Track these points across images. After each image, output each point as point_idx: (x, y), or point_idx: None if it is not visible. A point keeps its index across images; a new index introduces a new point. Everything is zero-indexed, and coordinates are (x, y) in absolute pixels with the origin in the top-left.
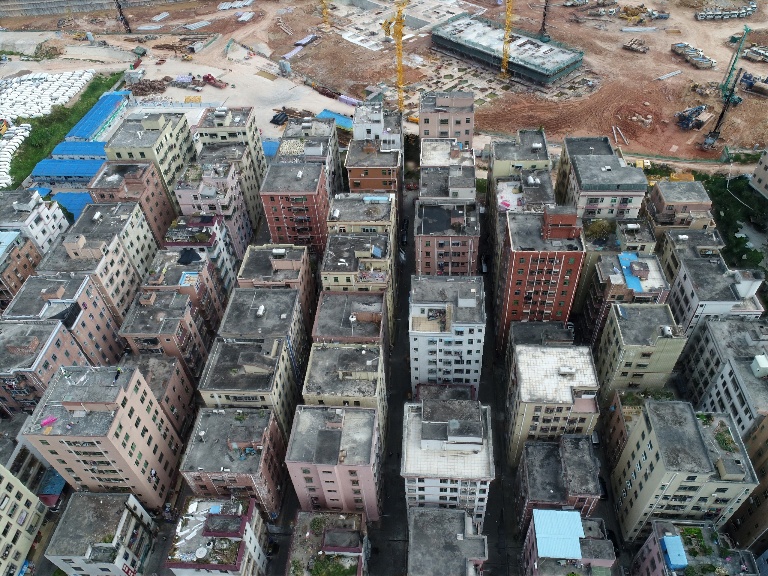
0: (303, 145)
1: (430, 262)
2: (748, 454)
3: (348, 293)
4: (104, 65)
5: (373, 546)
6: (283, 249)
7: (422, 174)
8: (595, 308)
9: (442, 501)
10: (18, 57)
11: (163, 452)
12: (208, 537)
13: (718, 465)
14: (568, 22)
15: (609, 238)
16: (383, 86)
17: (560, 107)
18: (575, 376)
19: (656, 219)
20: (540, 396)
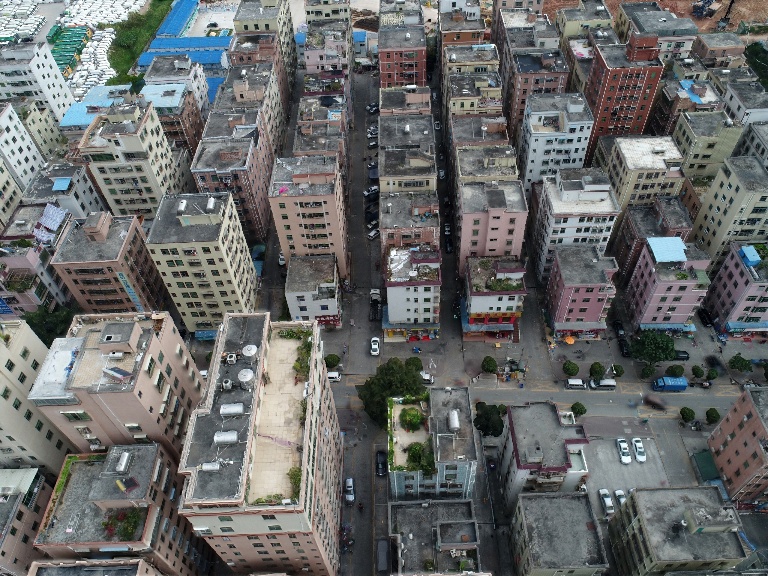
0: (399, 18)
1: (525, 99)
2: None
3: (472, 116)
4: None
5: None
6: (415, 85)
7: None
8: (662, 126)
9: (575, 244)
10: None
11: None
12: (413, 266)
13: None
14: None
15: (668, 74)
16: None
17: None
18: (665, 153)
19: None
20: (642, 166)
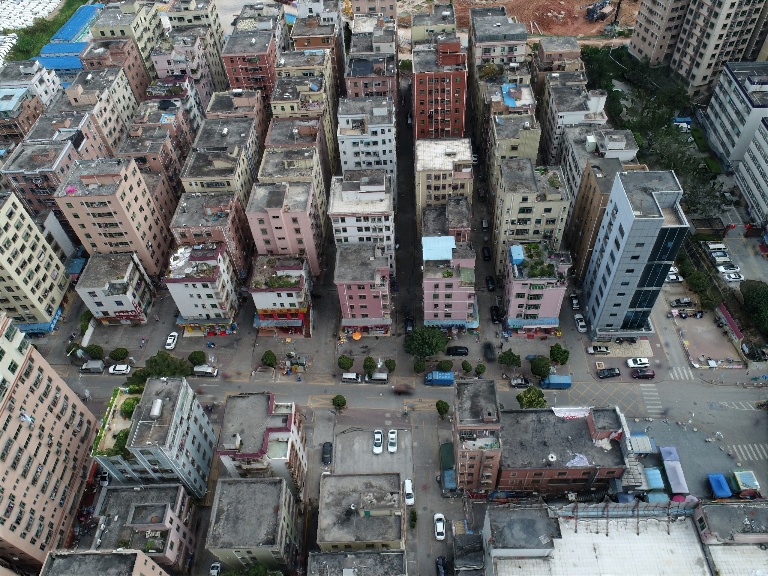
0: (256, 23)
1: None
2: (579, 203)
3: (293, 119)
4: None
5: (317, 294)
6: (241, 89)
7: (353, 39)
8: (485, 128)
9: (361, 242)
10: None
11: (156, 234)
12: (193, 264)
13: (545, 193)
14: None
15: (498, 78)
16: None
17: None
18: (457, 155)
19: (540, 68)
20: (430, 168)
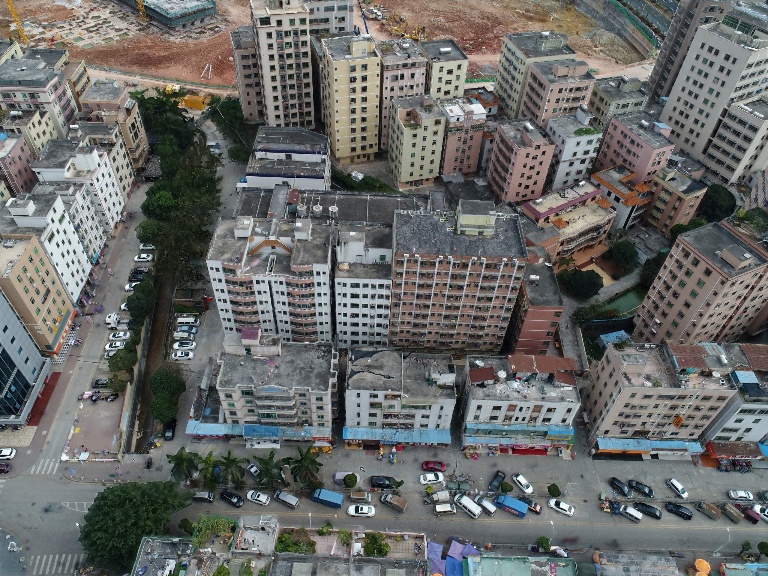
0: None
1: None
2: None
3: None
4: None
5: None
6: None
7: None
8: None
9: None
10: None
11: None
12: None
13: None
14: None
15: None
16: (26, 22)
17: (176, 47)
18: None
19: None
20: None
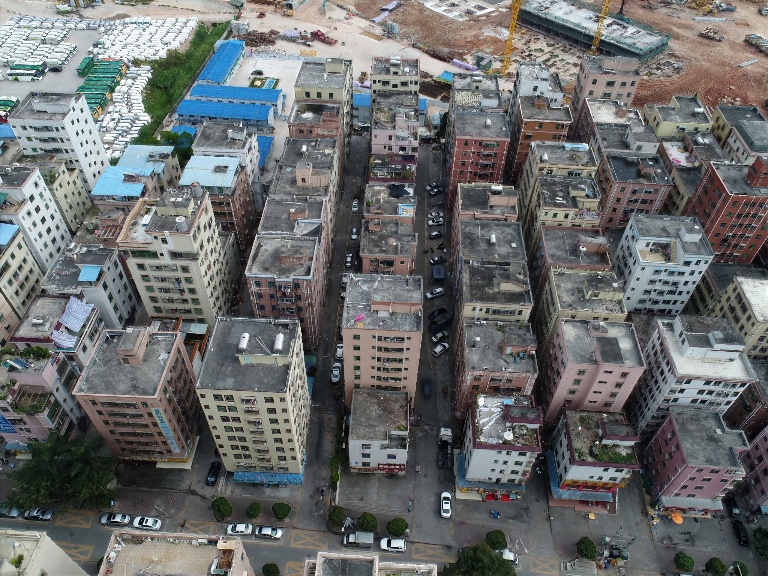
0: (475, 97)
1: (617, 208)
2: None
3: (565, 228)
4: (204, 14)
5: None
6: (501, 186)
7: None
8: None
9: (691, 404)
10: (111, 0)
11: None
12: (507, 424)
13: None
14: (641, 8)
15: None
16: None
17: (652, 85)
18: None
19: None
20: None
